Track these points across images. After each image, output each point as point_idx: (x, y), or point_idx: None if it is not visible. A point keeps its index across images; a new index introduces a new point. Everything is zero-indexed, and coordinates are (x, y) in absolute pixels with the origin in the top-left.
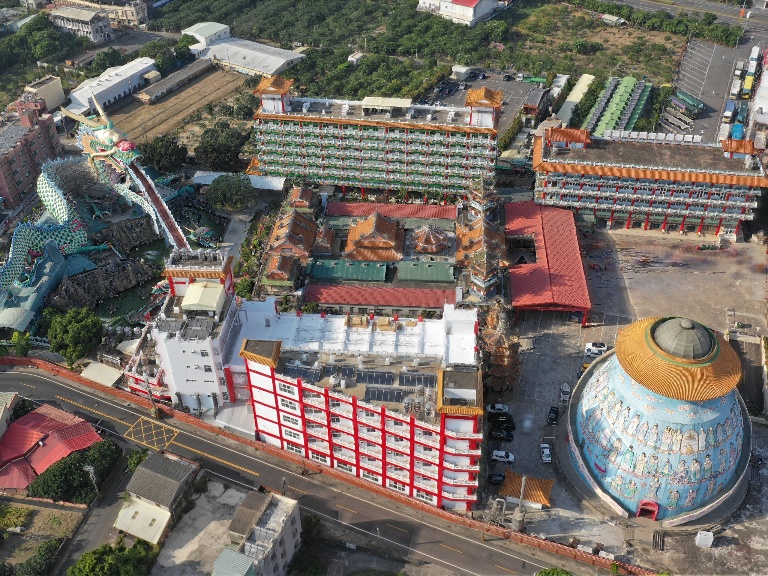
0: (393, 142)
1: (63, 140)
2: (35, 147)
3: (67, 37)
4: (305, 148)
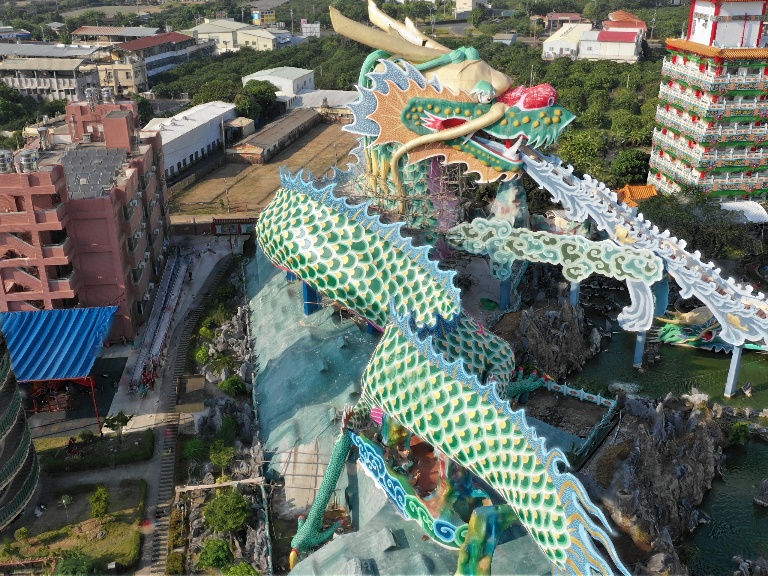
0: None
1: None
2: (148, 193)
3: (30, 101)
4: None
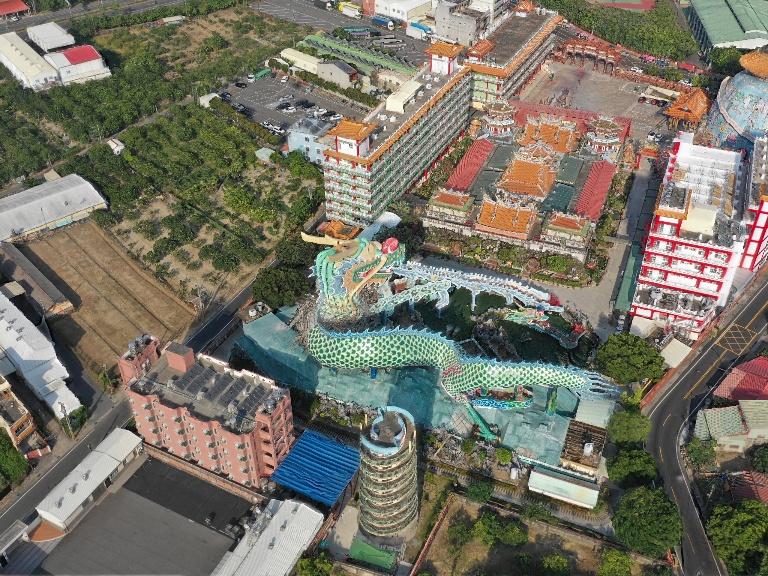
0: None
1: (115, 398)
2: None
3: None
4: None
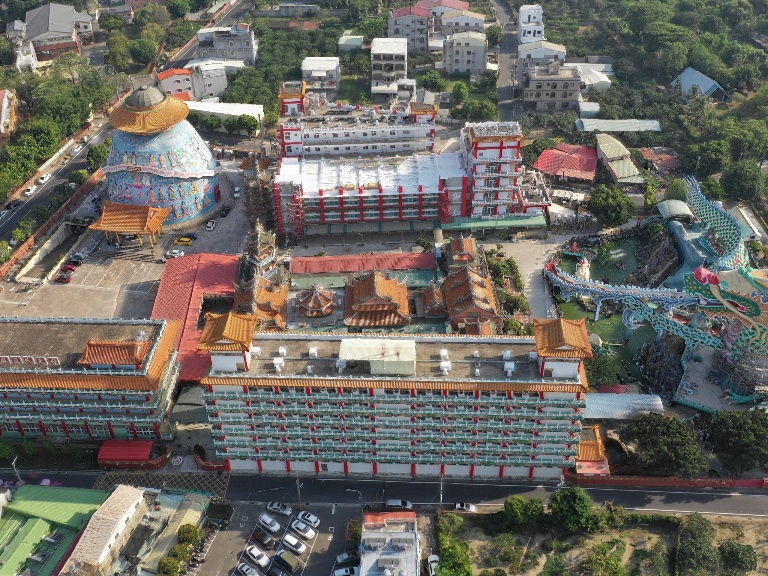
0: None
1: None
2: None
3: None
4: None
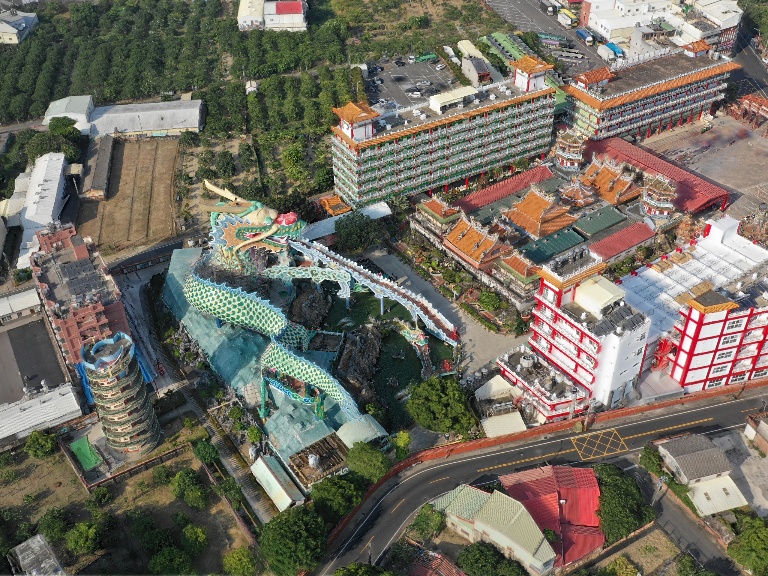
0: (474, 129)
1: None
2: None
3: None
4: (401, 164)
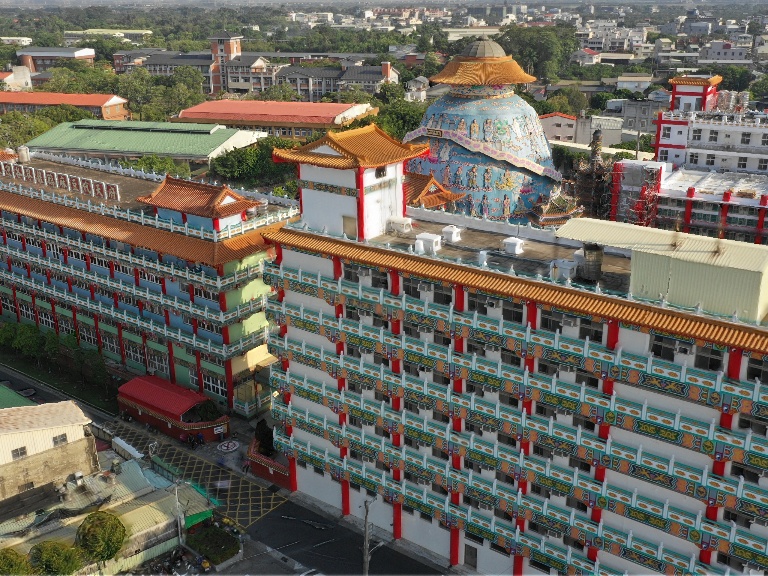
0: None
1: None
2: None
3: None
4: None
